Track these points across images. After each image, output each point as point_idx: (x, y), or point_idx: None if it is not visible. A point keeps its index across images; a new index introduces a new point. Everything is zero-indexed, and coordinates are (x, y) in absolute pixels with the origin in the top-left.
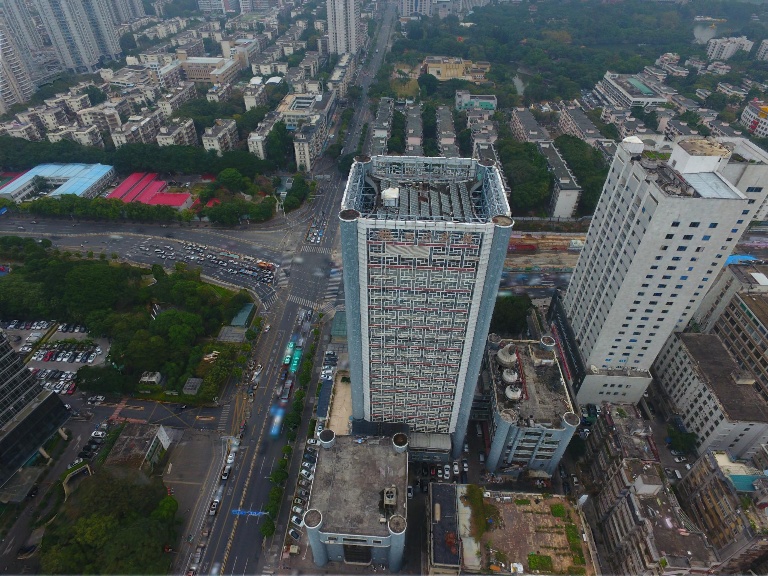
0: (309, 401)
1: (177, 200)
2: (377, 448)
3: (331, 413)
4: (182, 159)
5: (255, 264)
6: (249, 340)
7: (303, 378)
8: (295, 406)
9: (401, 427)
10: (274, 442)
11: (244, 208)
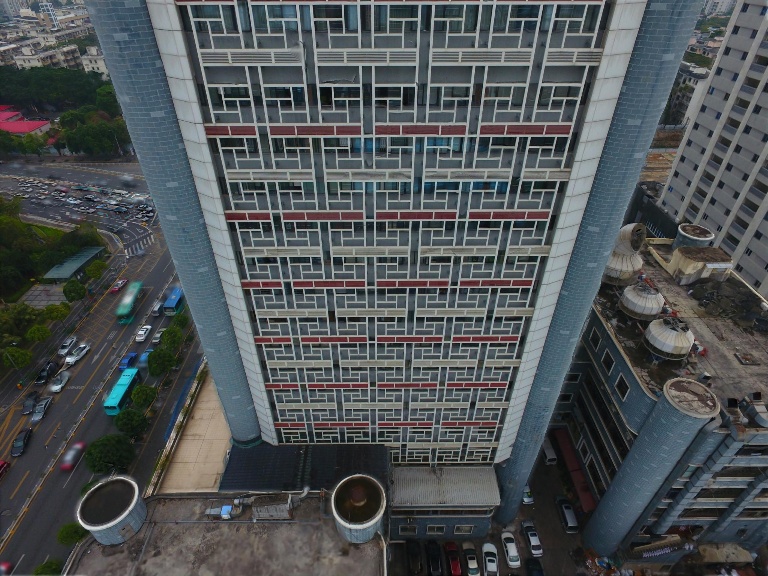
0: (170, 410)
1: (24, 126)
2: (283, 531)
3: (185, 430)
4: (46, 81)
5: (129, 200)
6: (70, 301)
7: (155, 360)
8: (120, 421)
9: (365, 455)
10: (61, 512)
11: (127, 134)
